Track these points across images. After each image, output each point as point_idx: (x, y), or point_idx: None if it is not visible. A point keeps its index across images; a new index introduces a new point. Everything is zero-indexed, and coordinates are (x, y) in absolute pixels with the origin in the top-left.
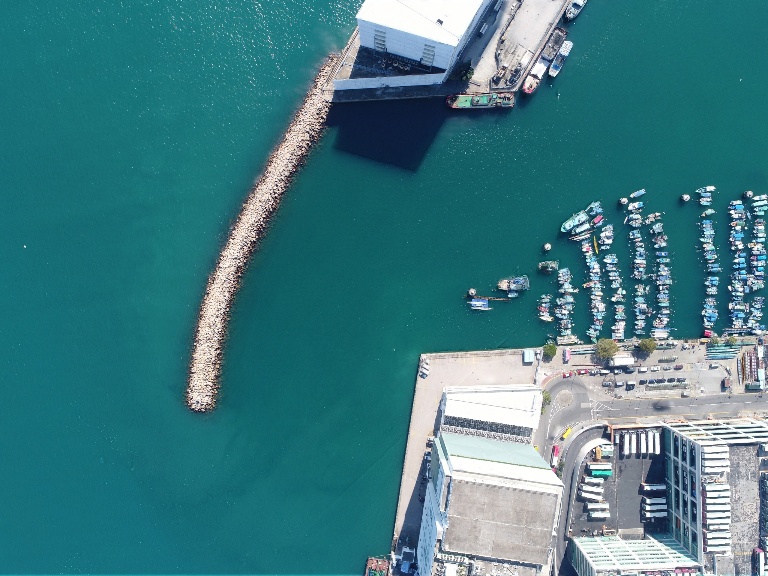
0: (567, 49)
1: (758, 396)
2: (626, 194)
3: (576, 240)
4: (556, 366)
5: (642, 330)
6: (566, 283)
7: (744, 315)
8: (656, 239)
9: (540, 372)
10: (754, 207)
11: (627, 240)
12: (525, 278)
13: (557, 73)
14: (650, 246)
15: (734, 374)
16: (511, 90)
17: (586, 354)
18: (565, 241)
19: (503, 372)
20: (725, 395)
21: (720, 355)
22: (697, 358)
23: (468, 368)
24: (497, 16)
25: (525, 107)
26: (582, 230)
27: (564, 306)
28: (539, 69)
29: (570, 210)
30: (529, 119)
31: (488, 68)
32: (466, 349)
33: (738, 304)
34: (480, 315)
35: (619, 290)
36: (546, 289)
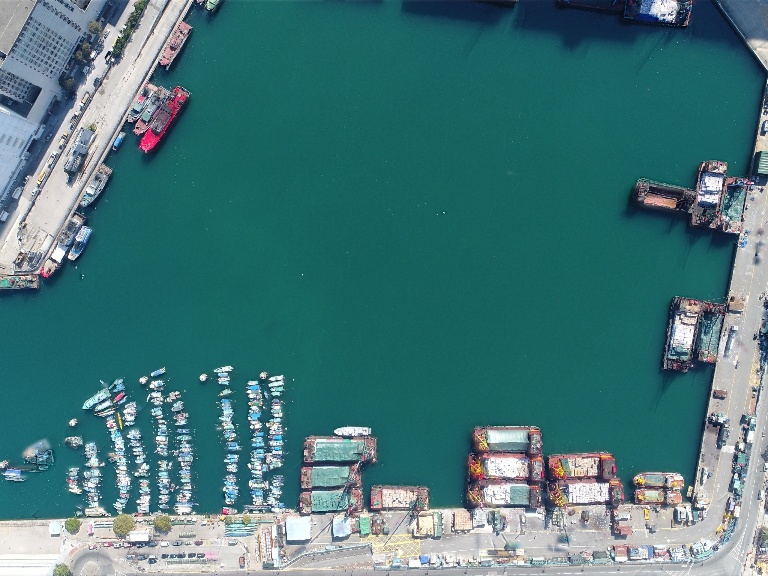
0: (81, 235)
1: (276, 573)
2: (147, 373)
3: (101, 416)
4: (82, 538)
5: (166, 504)
6: (93, 457)
7: (262, 493)
8: (177, 417)
9: (67, 543)
10: (270, 387)
11: (151, 417)
12: (49, 453)
13: (77, 257)
14: (172, 423)
15: (252, 551)
16: (34, 273)
17: (110, 527)
18: (93, 416)
19: (33, 542)
20: (244, 571)
21: (237, 532)
22: (217, 534)
23: (0, 537)
24: (19, 202)
25: (52, 287)
26: (103, 408)
27: (91, 479)
28: (57, 254)
29: (95, 387)
30: (55, 299)
31: (12, 251)
32: (1, 518)
33: (255, 482)
34: (13, 486)
35: (143, 465)
36: (76, 462)
